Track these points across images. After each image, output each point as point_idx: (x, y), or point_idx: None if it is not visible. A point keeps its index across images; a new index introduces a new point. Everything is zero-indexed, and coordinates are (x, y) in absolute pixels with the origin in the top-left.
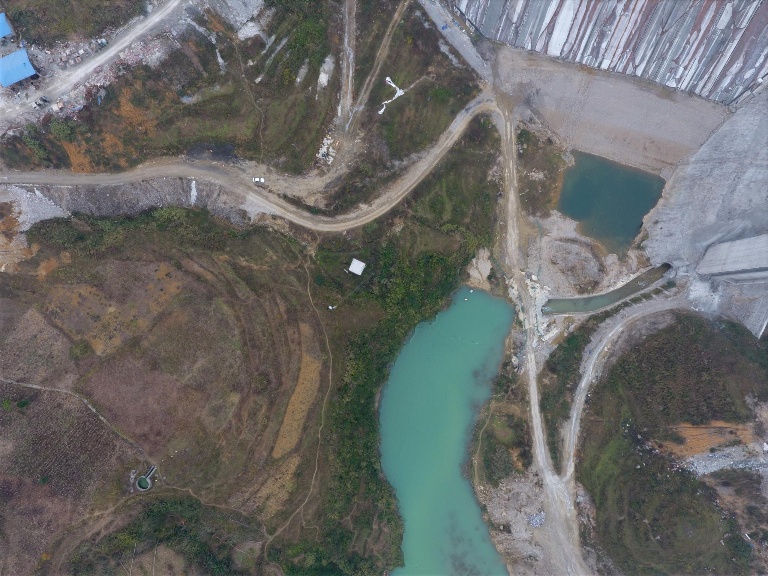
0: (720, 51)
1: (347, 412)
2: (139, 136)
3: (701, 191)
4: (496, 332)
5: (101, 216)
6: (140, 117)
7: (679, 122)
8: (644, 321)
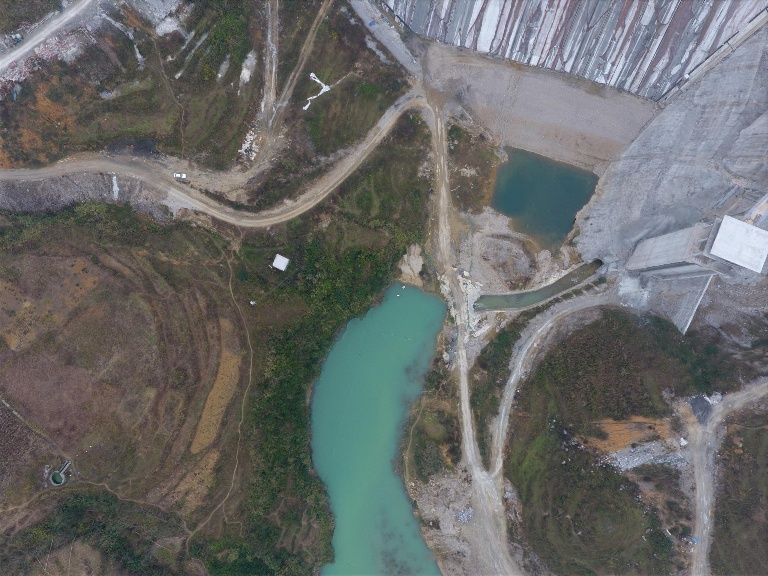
0: (646, 47)
1: (270, 407)
2: (58, 131)
3: (628, 187)
4: (428, 328)
5: (23, 211)
6: (58, 112)
7: (609, 118)
8: (573, 317)
